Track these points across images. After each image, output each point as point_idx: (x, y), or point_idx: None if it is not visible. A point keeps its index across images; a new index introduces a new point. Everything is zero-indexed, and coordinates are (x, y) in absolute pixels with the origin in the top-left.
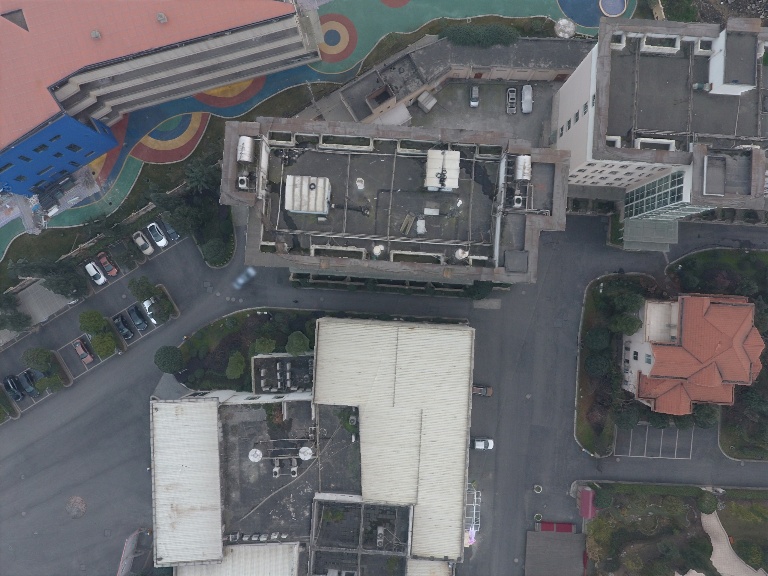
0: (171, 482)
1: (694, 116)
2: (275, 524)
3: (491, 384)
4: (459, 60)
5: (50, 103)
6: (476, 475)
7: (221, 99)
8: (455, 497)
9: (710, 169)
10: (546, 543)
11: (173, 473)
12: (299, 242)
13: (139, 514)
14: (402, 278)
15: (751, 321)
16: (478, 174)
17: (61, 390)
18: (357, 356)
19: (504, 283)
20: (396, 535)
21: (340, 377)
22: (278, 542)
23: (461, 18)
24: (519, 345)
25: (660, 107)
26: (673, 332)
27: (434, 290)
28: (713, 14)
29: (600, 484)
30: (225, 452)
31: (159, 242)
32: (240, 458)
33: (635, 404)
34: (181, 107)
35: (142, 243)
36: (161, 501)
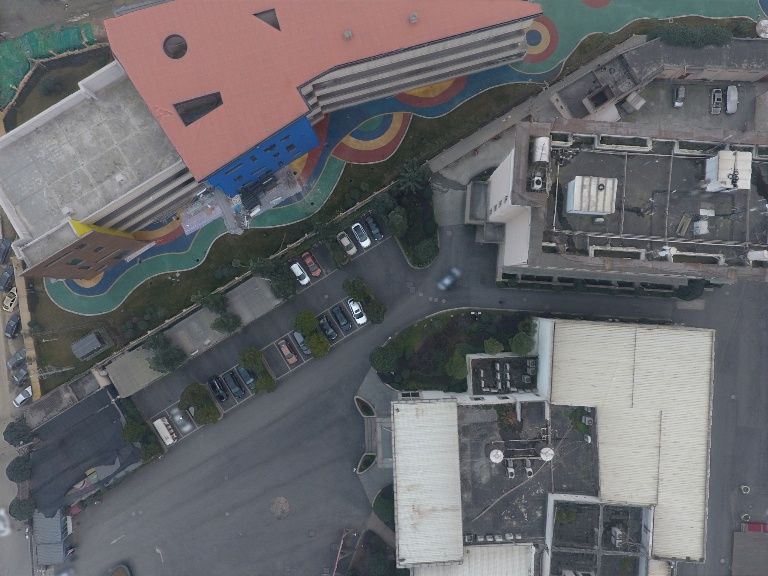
0: (412, 483)
1: None
2: (507, 525)
3: None
4: (672, 60)
5: (299, 103)
6: None
7: (422, 99)
8: (696, 498)
9: None
10: (753, 544)
11: (414, 474)
12: (574, 243)
13: (343, 515)
14: (617, 279)
15: None
16: (752, 175)
17: (264, 390)
18: (594, 357)
19: None
20: (629, 536)
21: (577, 378)
22: (512, 543)
23: (663, 18)
24: (723, 346)
25: None
26: None
27: (643, 291)
28: None
29: None
30: None
31: (363, 242)
32: (472, 459)
33: None
34: (382, 107)
35: (348, 243)
36: (403, 502)
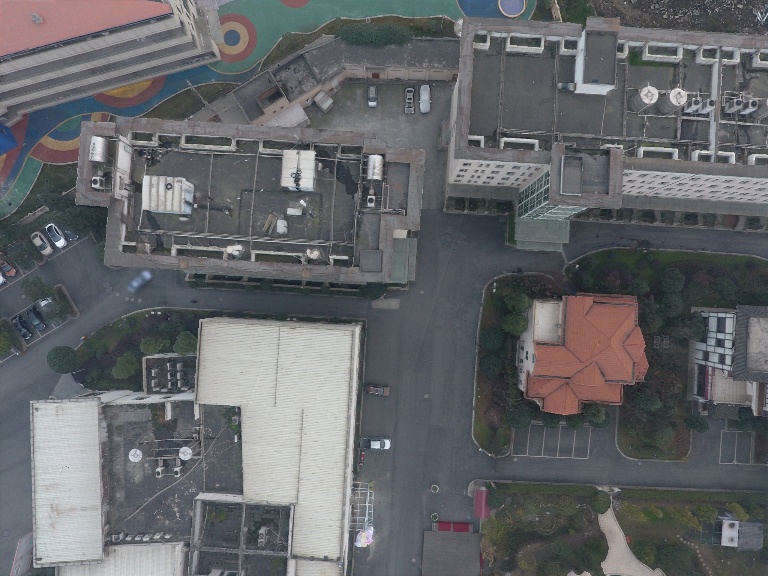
0: (51, 482)
1: (560, 116)
2: (160, 524)
3: (389, 384)
4: (353, 60)
5: None
6: (374, 475)
7: (121, 99)
8: (335, 497)
9: (567, 169)
10: (443, 543)
11: (53, 473)
12: (162, 242)
13: None
14: (295, 278)
15: (634, 320)
16: (342, 174)
17: None
18: (239, 356)
19: (398, 283)
20: (280, 535)
21: (222, 377)
22: (162, 542)
23: (360, 18)
24: (417, 345)
25: (526, 107)
26: None
27: (330, 290)
28: (615, 14)
29: (496, 484)
30: (110, 452)
31: (57, 242)
32: (125, 458)
33: (532, 404)
34: (81, 107)
35: (40, 243)
36: (41, 501)
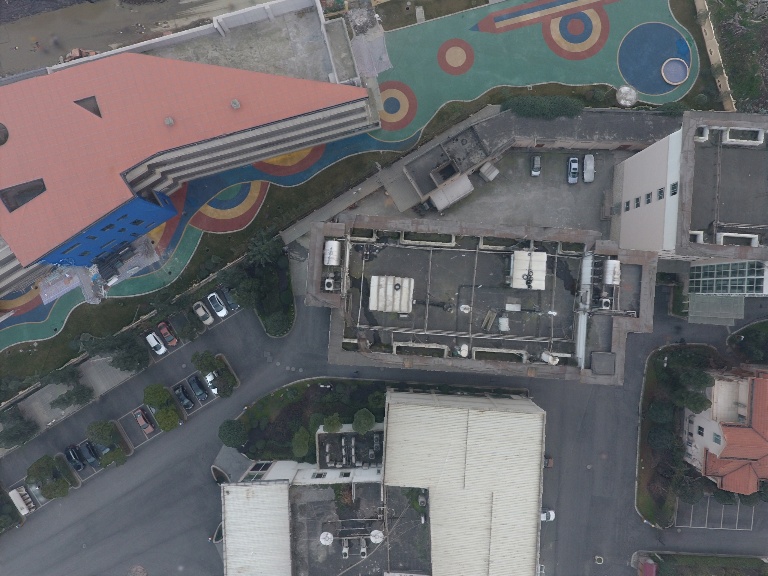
0: (243, 565)
1: None
2: None
3: (552, 455)
4: (523, 132)
5: (122, 189)
6: None
7: (280, 168)
8: None
9: None
10: None
11: (245, 556)
12: (380, 338)
13: None
14: None
15: None
16: (560, 269)
17: None
18: (427, 438)
19: None
20: None
21: (410, 459)
22: None
23: (522, 86)
24: (580, 415)
25: (742, 200)
26: (741, 411)
27: None
28: None
29: (662, 556)
30: (294, 532)
31: (219, 312)
32: (309, 538)
33: (697, 475)
34: (240, 176)
35: (203, 314)
36: None
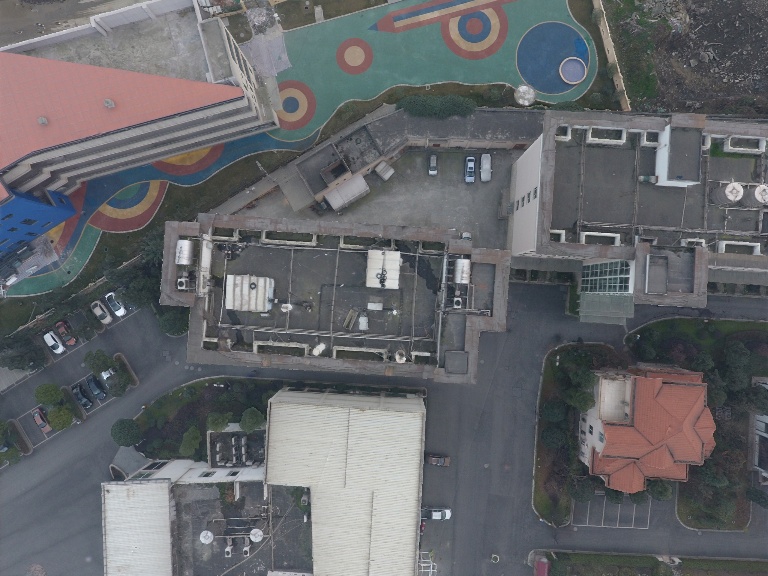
0: (123, 563)
1: (640, 208)
2: None
3: (449, 453)
4: (416, 131)
5: None
6: (434, 544)
7: (179, 167)
8: None
9: (652, 268)
10: None
11: (125, 554)
12: (243, 337)
13: None
14: None
15: (703, 401)
16: (422, 268)
17: (21, 458)
18: (309, 437)
19: None
20: None
21: (292, 458)
22: None
23: (420, 85)
24: (477, 414)
25: (606, 199)
26: (627, 410)
27: None
28: (675, 79)
29: (557, 554)
30: (178, 530)
31: (117, 311)
32: (193, 536)
33: None
34: (139, 175)
35: (100, 313)
36: None
